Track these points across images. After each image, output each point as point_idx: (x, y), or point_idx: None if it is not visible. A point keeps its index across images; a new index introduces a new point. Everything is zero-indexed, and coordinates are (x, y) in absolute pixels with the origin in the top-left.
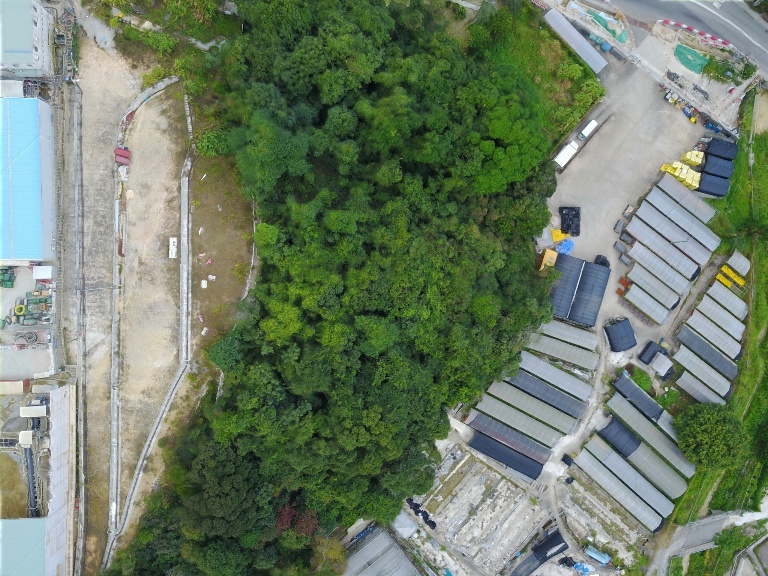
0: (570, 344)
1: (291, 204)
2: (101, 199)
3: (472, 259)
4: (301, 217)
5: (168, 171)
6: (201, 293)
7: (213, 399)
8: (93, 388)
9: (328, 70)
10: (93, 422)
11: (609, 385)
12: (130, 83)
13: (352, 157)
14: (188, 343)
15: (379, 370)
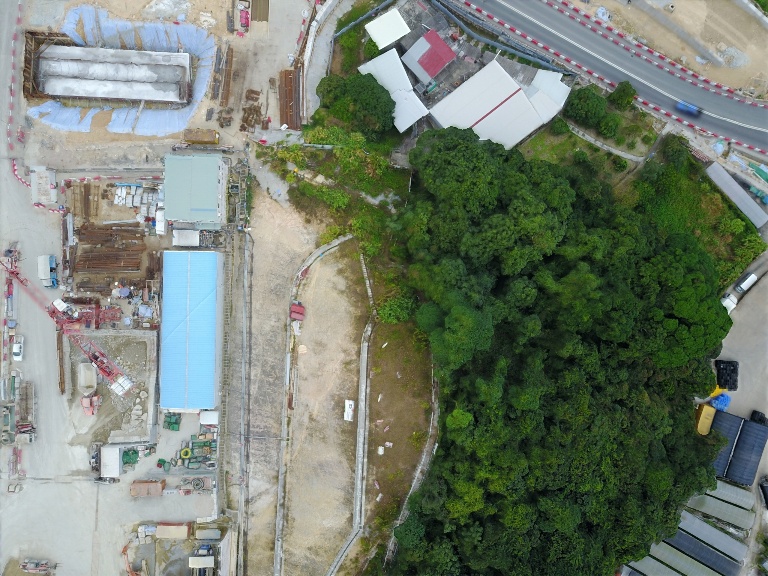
0: (726, 502)
1: (481, 386)
2: (271, 349)
3: (645, 430)
4: (490, 398)
5: (346, 333)
6: (378, 459)
7: (382, 562)
8: (255, 536)
9: (516, 248)
10: (254, 570)
11: (764, 545)
12: (304, 237)
13: (536, 333)
14: (362, 507)
15: (554, 546)
